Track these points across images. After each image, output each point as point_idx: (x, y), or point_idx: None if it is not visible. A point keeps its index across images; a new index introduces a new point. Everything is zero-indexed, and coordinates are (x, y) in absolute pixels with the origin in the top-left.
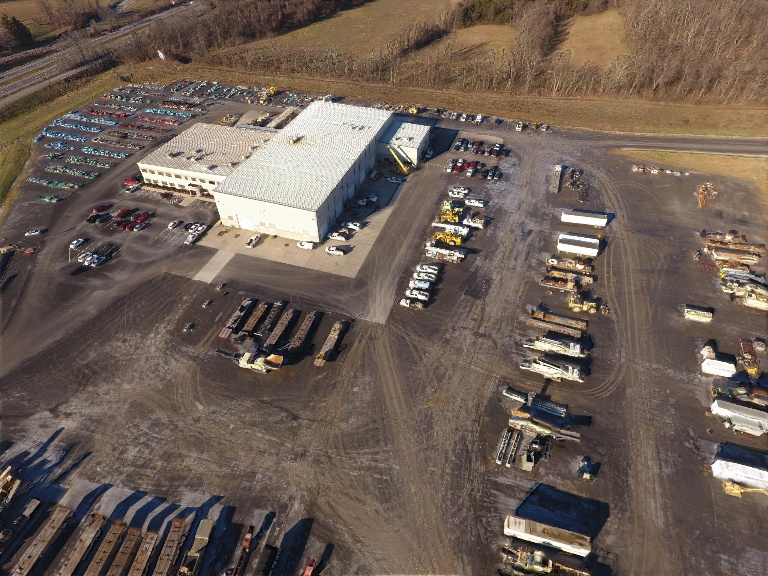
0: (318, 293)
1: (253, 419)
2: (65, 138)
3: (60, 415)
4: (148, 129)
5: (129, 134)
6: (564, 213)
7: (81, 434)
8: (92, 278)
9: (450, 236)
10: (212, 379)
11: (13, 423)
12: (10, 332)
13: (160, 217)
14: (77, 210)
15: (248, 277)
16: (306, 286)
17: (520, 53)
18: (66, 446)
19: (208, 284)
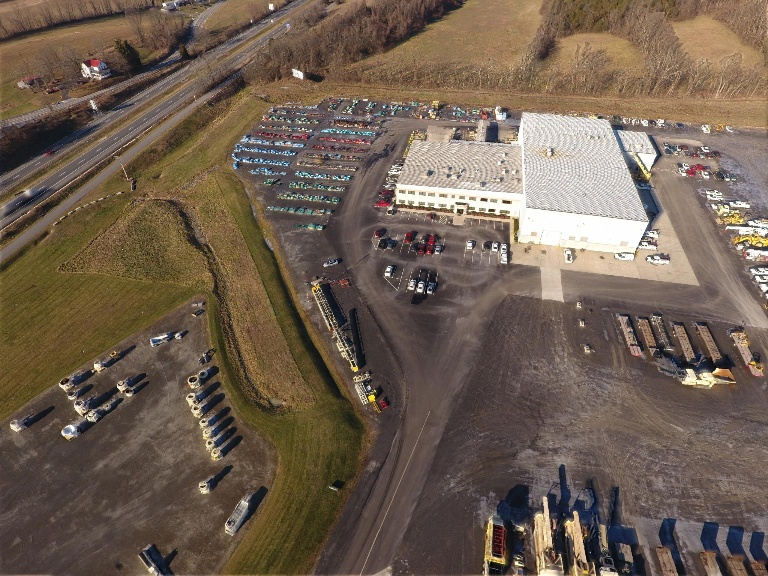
0: (681, 303)
1: (743, 436)
2: (265, 163)
3: (546, 452)
4: (345, 149)
5: (330, 156)
6: None
7: (588, 469)
8: (439, 306)
9: (756, 238)
10: (663, 399)
11: (506, 465)
12: (410, 369)
13: (447, 238)
14: (353, 237)
15: (596, 293)
16: (662, 297)
17: None
18: (585, 484)
19: (564, 303)
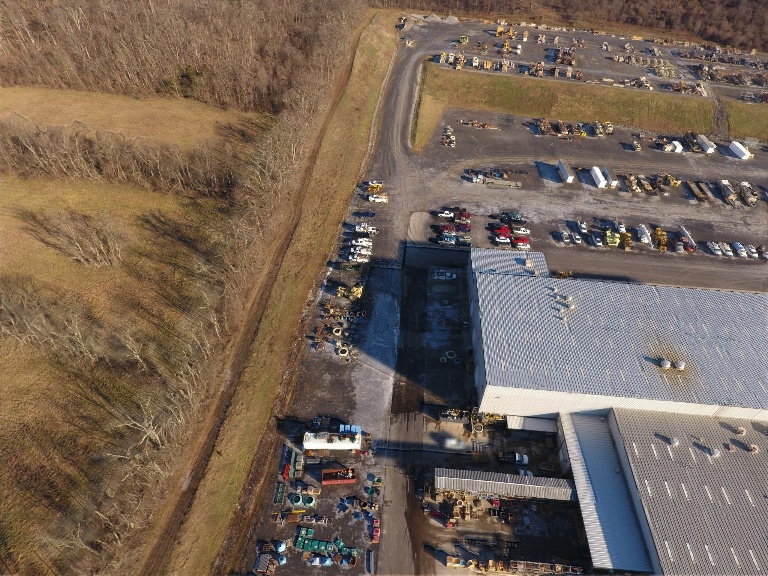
0: None
1: None
2: None
3: None
4: None
5: None
6: (573, 176)
7: None
8: None
9: None
10: None
11: None
12: None
13: None
14: None
15: None
16: None
17: (187, 165)
18: None
19: None
